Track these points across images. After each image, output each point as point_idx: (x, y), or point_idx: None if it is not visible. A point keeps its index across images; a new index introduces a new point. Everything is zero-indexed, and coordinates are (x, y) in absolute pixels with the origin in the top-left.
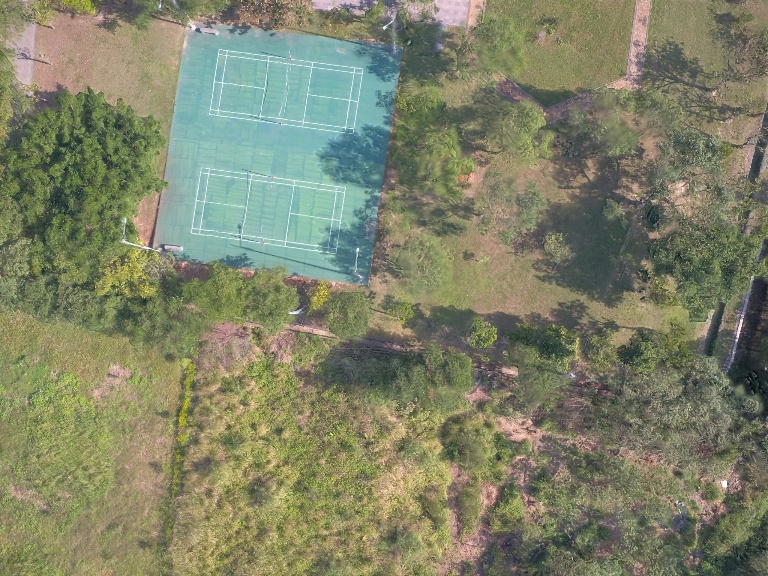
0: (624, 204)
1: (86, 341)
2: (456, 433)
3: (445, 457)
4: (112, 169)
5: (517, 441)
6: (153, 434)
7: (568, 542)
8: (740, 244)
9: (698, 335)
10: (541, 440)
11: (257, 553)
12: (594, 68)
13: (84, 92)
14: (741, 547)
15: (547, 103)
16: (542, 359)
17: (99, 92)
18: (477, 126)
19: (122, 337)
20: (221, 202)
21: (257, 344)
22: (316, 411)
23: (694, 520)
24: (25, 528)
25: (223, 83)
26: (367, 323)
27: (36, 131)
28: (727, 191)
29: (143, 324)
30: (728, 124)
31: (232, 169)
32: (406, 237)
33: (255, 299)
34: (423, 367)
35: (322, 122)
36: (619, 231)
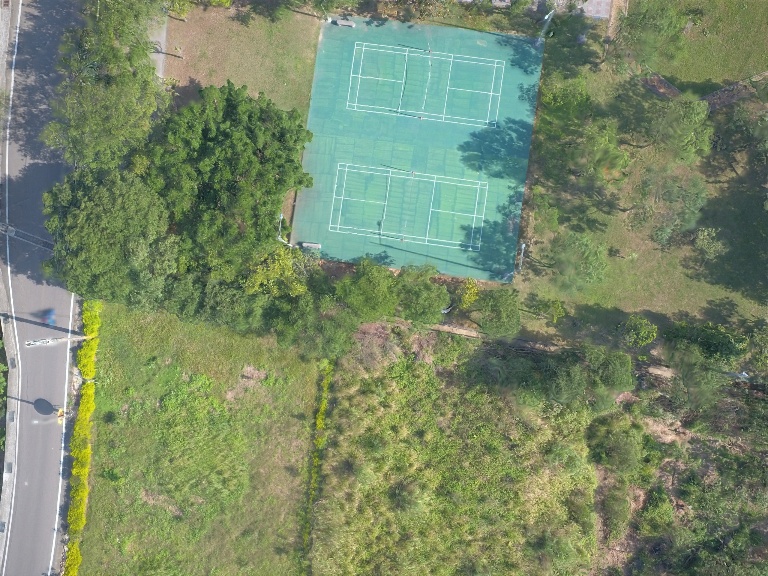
0: None
1: (219, 342)
2: (603, 435)
3: (591, 460)
4: (265, 164)
5: (666, 443)
6: (289, 437)
7: (720, 547)
8: None
9: None
10: (690, 442)
11: (400, 559)
12: (741, 59)
13: (217, 86)
14: None
15: (693, 95)
16: None
17: (243, 85)
18: (622, 119)
19: (256, 337)
20: (360, 198)
21: (397, 344)
22: (458, 413)
23: None
24: (157, 534)
25: (360, 76)
26: (519, 322)
27: (182, 125)
28: None
29: (294, 323)
30: None
31: (371, 164)
32: (555, 233)
33: (406, 297)
34: (585, 367)
35: (463, 116)
36: None
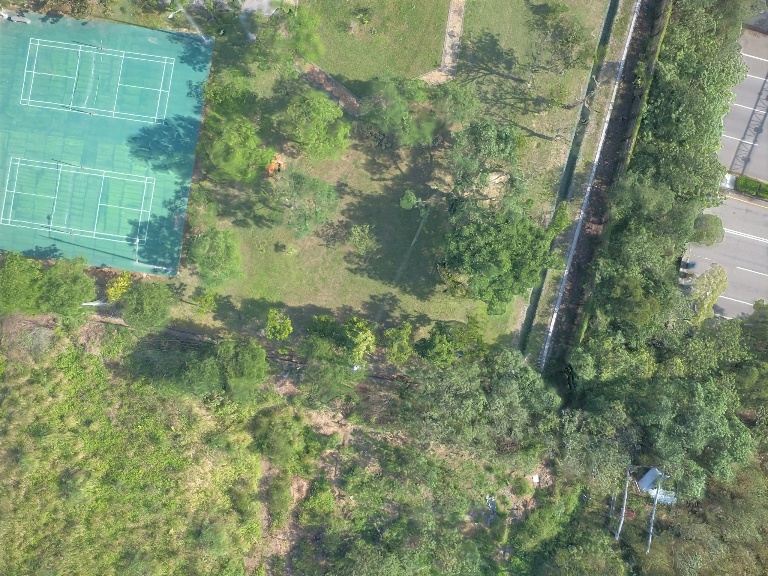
0: (437, 196)
1: None
2: (266, 426)
3: (256, 450)
4: None
5: (327, 434)
6: None
7: (377, 536)
8: (529, 237)
9: (511, 329)
10: (352, 434)
11: (63, 546)
12: (408, 59)
13: None
14: (550, 542)
15: (360, 94)
16: (339, 352)
17: None
18: (289, 117)
19: None
20: (31, 192)
21: (66, 336)
22: (125, 403)
23: (503, 515)
24: None
25: (34, 72)
26: (165, 315)
27: None
28: (519, 183)
29: None
30: (543, 116)
31: (42, 159)
32: None
33: (49, 290)
34: (212, 359)
35: (132, 112)
36: (432, 224)
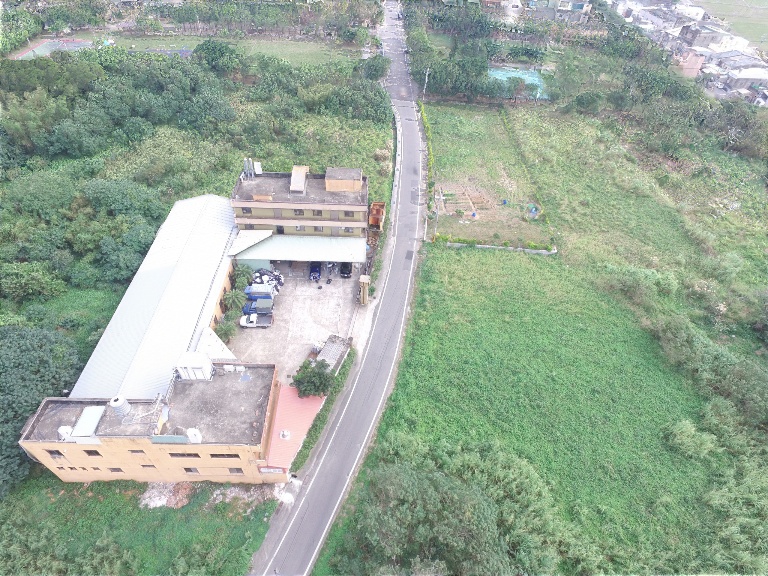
0: None
1: None
2: None
3: None
4: None
5: None
6: None
7: None
8: None
9: None
10: None
11: None
12: None
13: None
14: None
15: None
16: None
17: None
18: None
19: (476, 112)
20: None
21: None
22: None
23: None
24: None
25: None
26: None
27: None
28: None
29: None
30: None
31: None
32: None
33: None
34: None
35: None
36: None
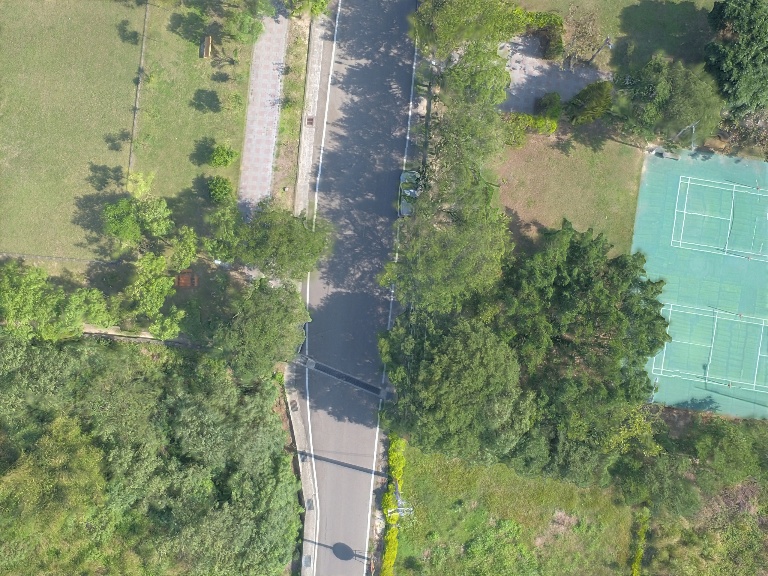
0: None
1: (529, 485)
2: None
3: None
4: (634, 321)
5: None
6: None
7: None
8: None
9: None
10: None
11: None
12: None
13: (535, 218)
14: None
15: None
16: None
17: (589, 228)
18: None
19: None
20: (684, 340)
21: (720, 494)
22: None
23: None
24: None
25: (685, 212)
26: None
27: (535, 273)
28: None
29: (652, 486)
30: None
31: (696, 305)
32: None
33: (760, 458)
34: None
35: None
36: None
